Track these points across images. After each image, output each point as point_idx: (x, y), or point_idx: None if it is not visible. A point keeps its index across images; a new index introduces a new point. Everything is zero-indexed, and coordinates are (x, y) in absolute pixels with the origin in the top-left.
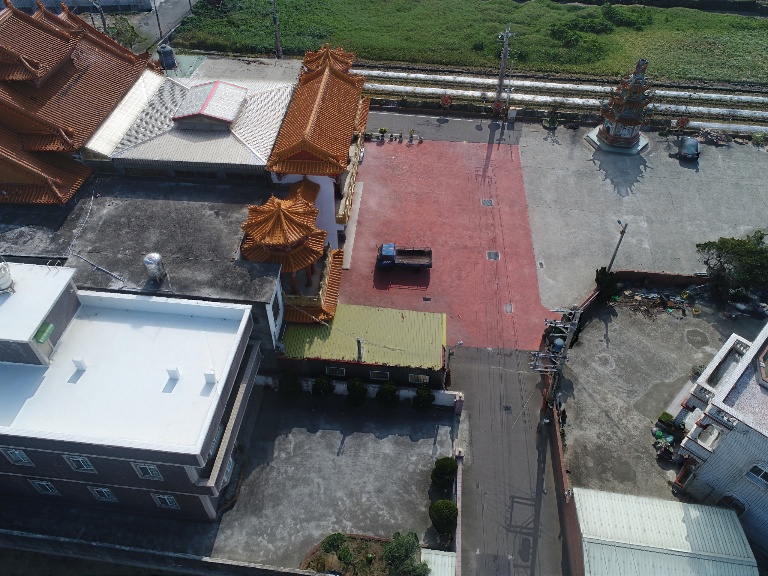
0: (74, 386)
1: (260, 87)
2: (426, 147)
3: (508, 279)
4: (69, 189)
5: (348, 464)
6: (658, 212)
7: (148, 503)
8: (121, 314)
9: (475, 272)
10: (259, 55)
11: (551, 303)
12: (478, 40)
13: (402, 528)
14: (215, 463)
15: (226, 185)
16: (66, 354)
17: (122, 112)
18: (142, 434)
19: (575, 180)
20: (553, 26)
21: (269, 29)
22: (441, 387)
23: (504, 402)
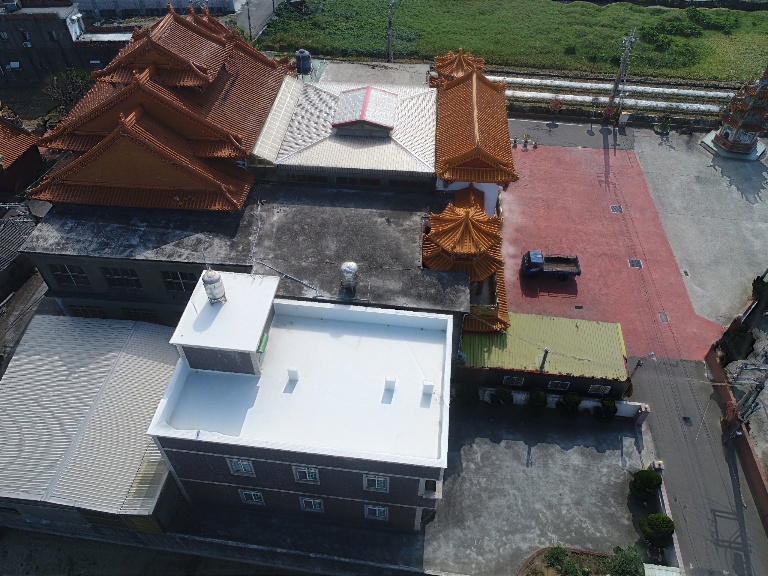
0: (291, 396)
1: (403, 92)
2: (542, 152)
3: (656, 287)
4: (240, 196)
5: (540, 475)
6: None
7: (356, 514)
8: (316, 323)
9: (621, 280)
10: (350, 58)
11: (705, 312)
12: (569, 44)
13: (609, 541)
14: None
15: (388, 192)
16: (274, 363)
17: (275, 118)
18: (374, 446)
19: (700, 186)
20: (641, 29)
21: (356, 32)
22: (622, 398)
23: (682, 413)
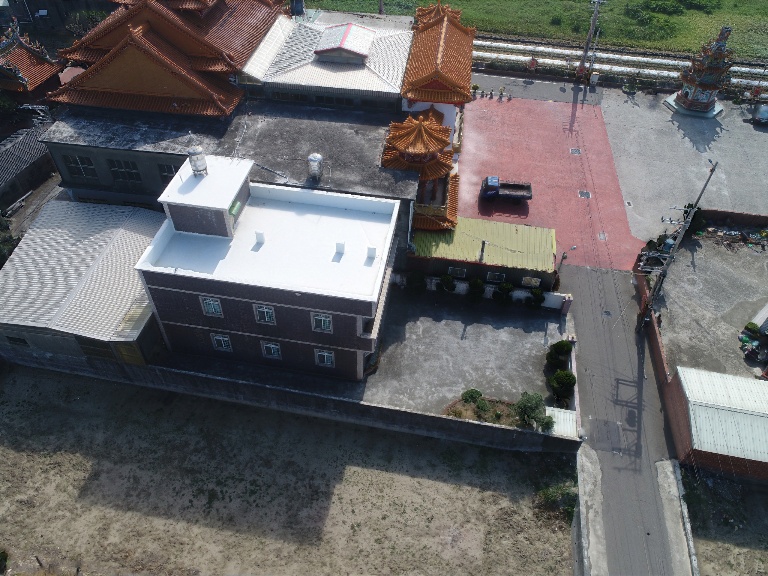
0: (257, 253)
1: (383, 33)
2: (515, 103)
3: (600, 213)
4: (229, 105)
5: (471, 346)
6: (735, 166)
7: (308, 360)
8: (285, 204)
9: (569, 206)
10: None
11: (641, 234)
12: (556, 15)
13: None
14: (375, 323)
15: (360, 111)
16: (245, 231)
17: (266, 46)
18: None
19: (656, 137)
20: (626, 6)
21: None
22: (551, 290)
23: (604, 308)
